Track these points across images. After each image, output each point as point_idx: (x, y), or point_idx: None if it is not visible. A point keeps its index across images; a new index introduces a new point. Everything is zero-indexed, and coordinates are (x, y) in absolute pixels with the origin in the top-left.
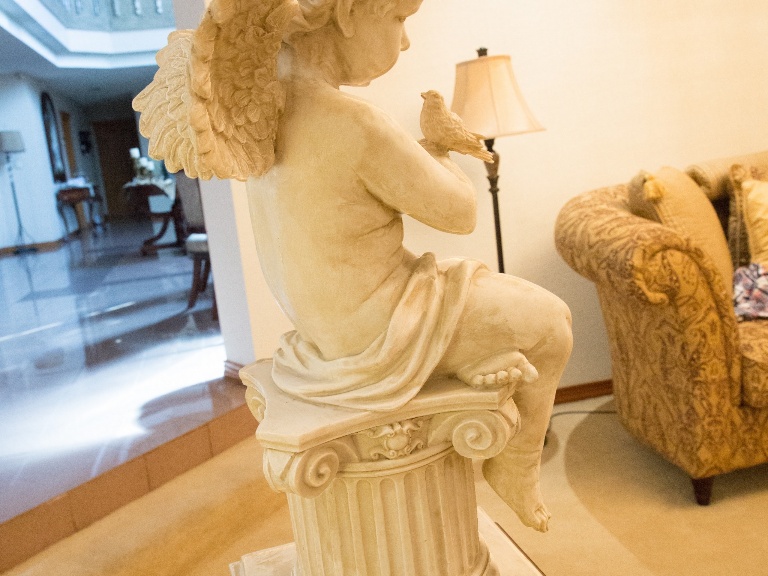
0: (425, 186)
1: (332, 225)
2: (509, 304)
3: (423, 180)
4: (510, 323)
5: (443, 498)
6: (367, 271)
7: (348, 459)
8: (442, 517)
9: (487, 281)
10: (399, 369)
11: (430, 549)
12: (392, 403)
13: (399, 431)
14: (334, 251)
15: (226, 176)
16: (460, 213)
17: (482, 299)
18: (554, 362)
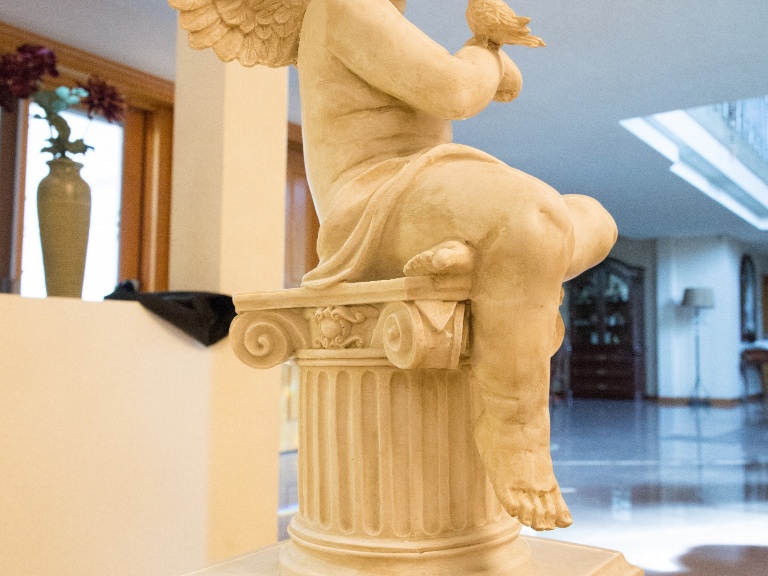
0: (389, 56)
1: (314, 105)
2: (457, 183)
3: (387, 50)
4: (450, 204)
5: (383, 417)
6: (339, 150)
7: (301, 344)
8: (379, 441)
9: (455, 163)
10: (340, 248)
11: (357, 472)
12: (321, 280)
13: (327, 314)
14: (317, 132)
15: (226, 59)
16: (432, 86)
17: (431, 178)
18: (514, 265)
